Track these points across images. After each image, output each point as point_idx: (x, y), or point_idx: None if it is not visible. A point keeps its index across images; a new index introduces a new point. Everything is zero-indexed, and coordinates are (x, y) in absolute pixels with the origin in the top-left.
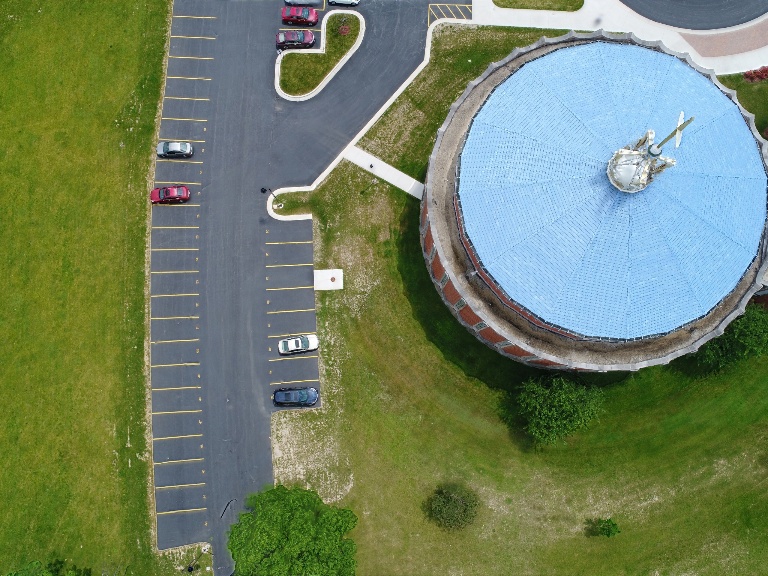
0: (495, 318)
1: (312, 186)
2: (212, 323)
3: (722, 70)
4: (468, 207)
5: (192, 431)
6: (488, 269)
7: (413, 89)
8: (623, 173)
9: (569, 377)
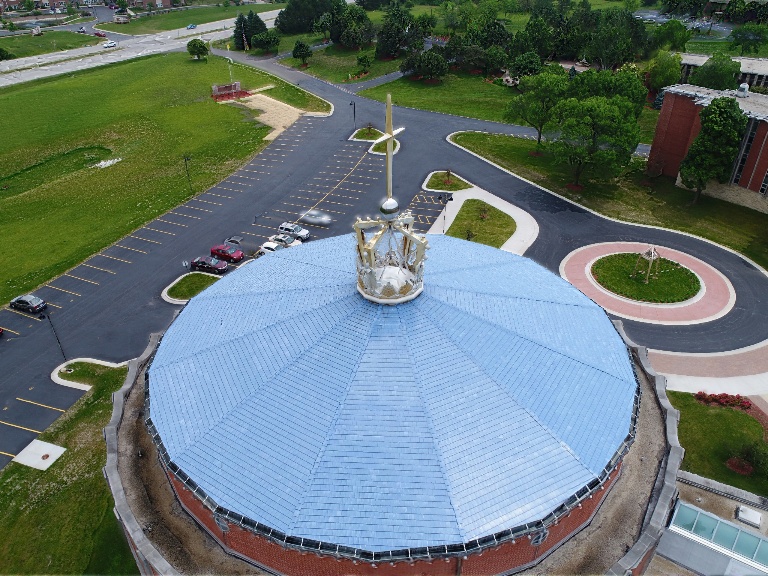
0: (130, 475)
1: (119, 364)
2: None
3: None
4: (187, 311)
5: None
6: (150, 374)
7: None
8: None
9: None
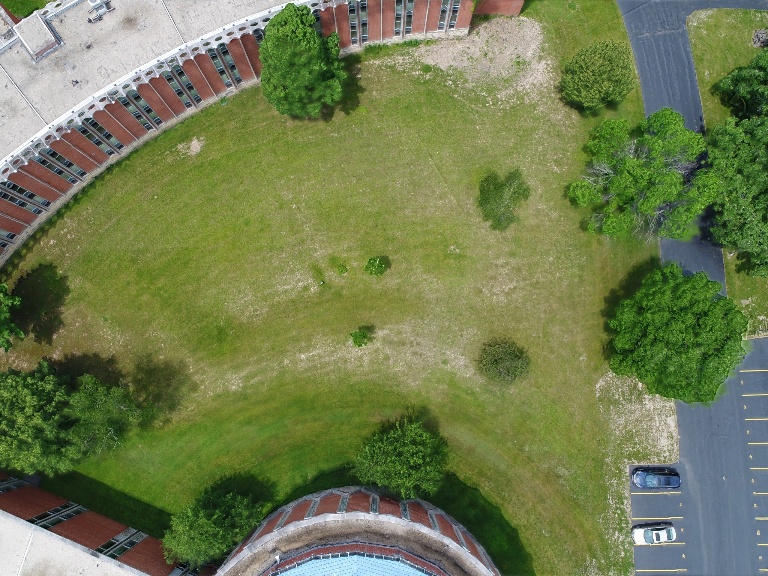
0: None
1: None
2: (745, 563)
3: None
4: None
5: (759, 448)
6: None
7: None
8: None
9: (390, 494)
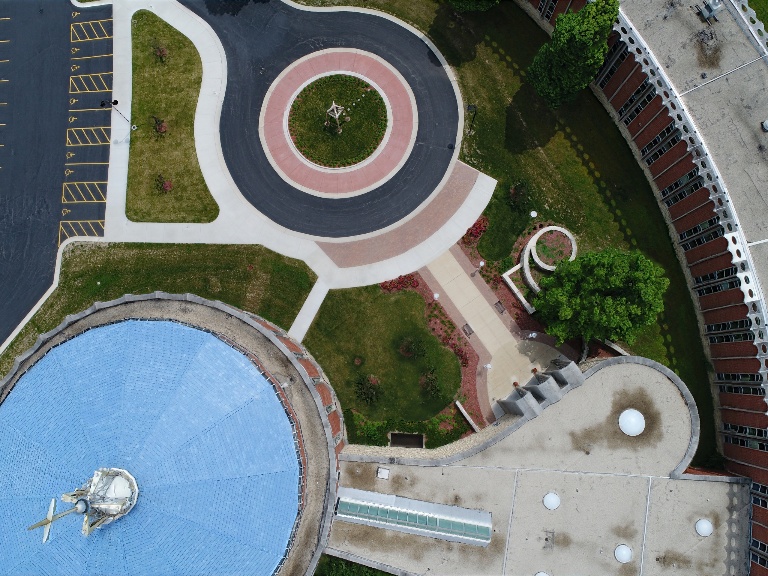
0: None
1: None
2: None
3: (359, 282)
4: None
5: None
6: None
7: (40, 317)
8: (99, 501)
9: None
